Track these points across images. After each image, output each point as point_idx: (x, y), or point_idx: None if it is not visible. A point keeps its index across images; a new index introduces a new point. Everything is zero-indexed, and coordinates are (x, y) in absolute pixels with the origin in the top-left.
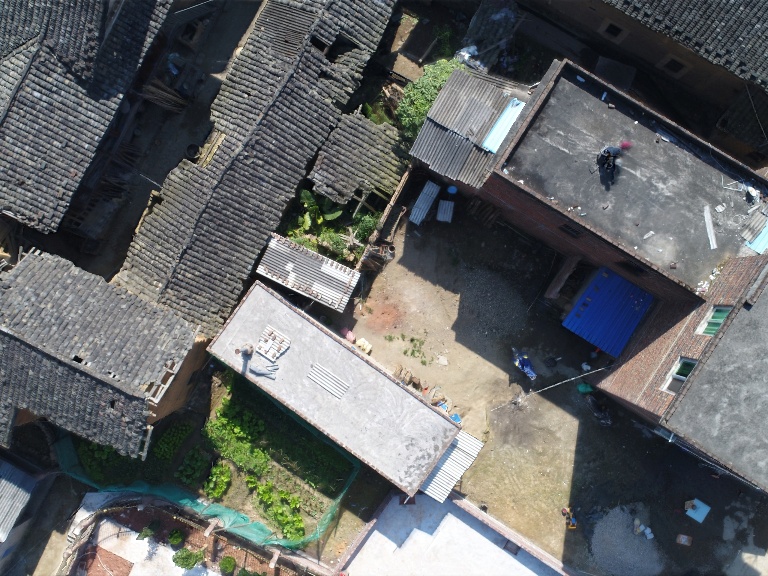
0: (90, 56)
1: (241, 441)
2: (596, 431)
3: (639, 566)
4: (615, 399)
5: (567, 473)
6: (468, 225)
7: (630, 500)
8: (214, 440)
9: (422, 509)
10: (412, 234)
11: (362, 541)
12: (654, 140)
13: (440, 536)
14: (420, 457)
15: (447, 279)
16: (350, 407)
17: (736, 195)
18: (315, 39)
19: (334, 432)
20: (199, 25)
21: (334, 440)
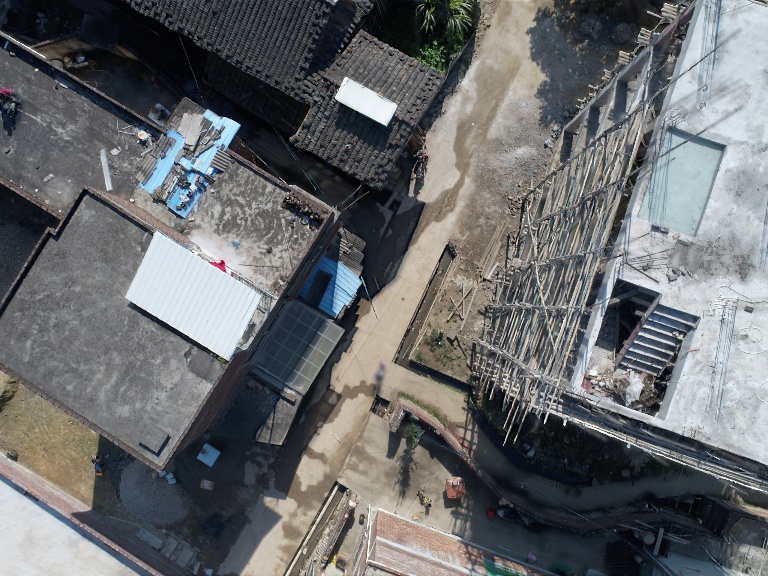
0: None
1: None
2: None
3: (155, 510)
4: None
5: None
6: None
7: None
8: None
9: None
10: None
11: None
12: (54, 87)
13: None
14: None
15: None
16: None
17: (131, 139)
18: None
19: None
20: None
21: None
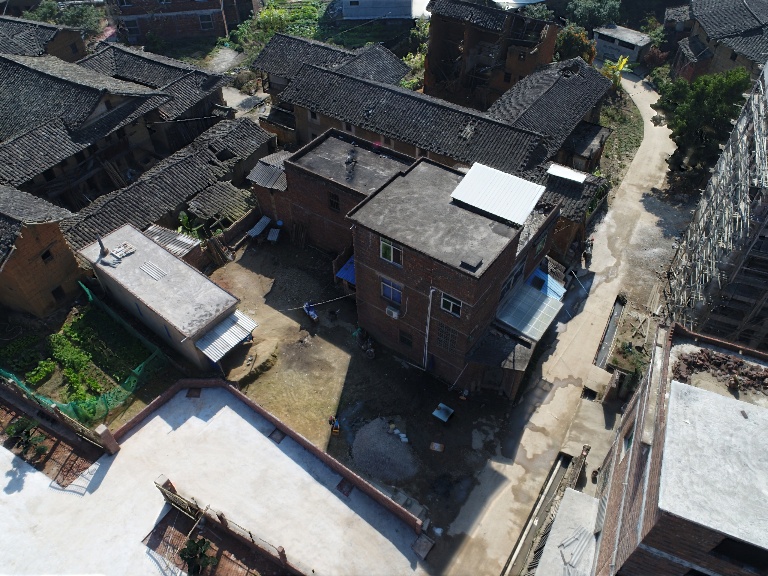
0: (81, 120)
1: (74, 346)
2: (364, 363)
3: (390, 457)
4: (376, 332)
5: (337, 392)
6: (289, 247)
7: (389, 413)
8: (53, 342)
9: (204, 401)
10: (250, 250)
11: (143, 423)
12: (379, 157)
13: (213, 423)
14: (203, 315)
15: (267, 271)
16: (163, 285)
17: None
18: (211, 147)
19: (145, 298)
20: (153, 159)
21: (142, 302)
